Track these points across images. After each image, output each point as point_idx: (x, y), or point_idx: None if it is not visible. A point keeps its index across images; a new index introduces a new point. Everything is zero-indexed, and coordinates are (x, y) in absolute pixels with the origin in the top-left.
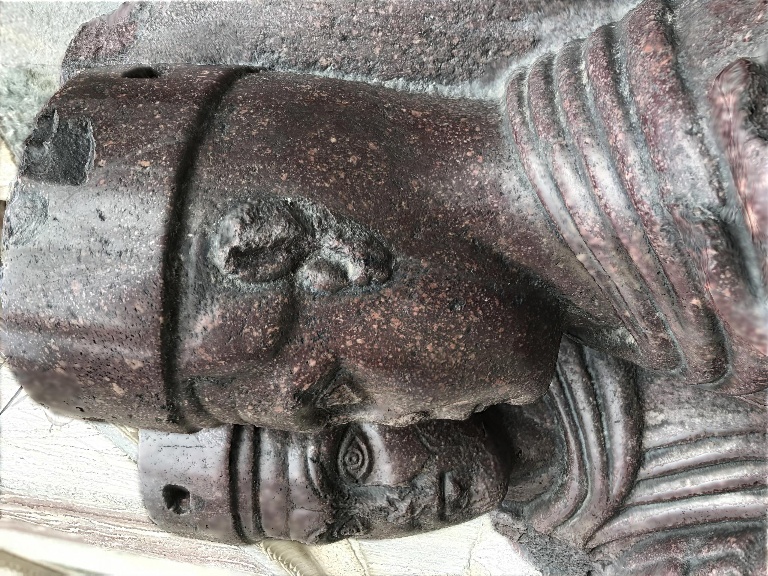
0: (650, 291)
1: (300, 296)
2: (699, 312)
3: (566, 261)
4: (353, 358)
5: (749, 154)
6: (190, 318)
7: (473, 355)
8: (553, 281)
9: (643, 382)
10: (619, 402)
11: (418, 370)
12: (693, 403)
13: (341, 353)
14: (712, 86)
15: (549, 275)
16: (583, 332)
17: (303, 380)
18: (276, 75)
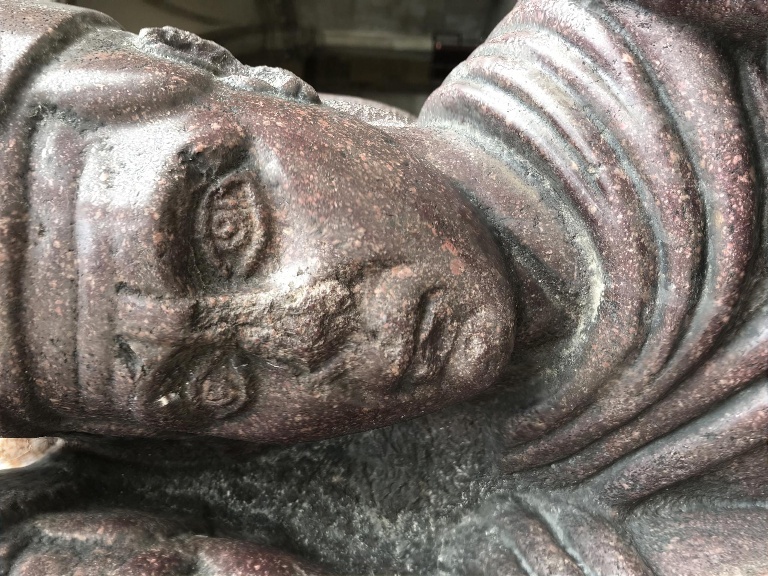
0: (584, 94)
1: (218, 84)
2: (634, 74)
3: (497, 172)
4: (268, 140)
5: None
6: (83, 51)
7: (414, 189)
8: (489, 198)
9: (649, 552)
10: (628, 575)
11: (348, 176)
12: (731, 560)
13: (254, 131)
14: None
15: (483, 189)
16: (540, 387)
17: (198, 139)
18: None
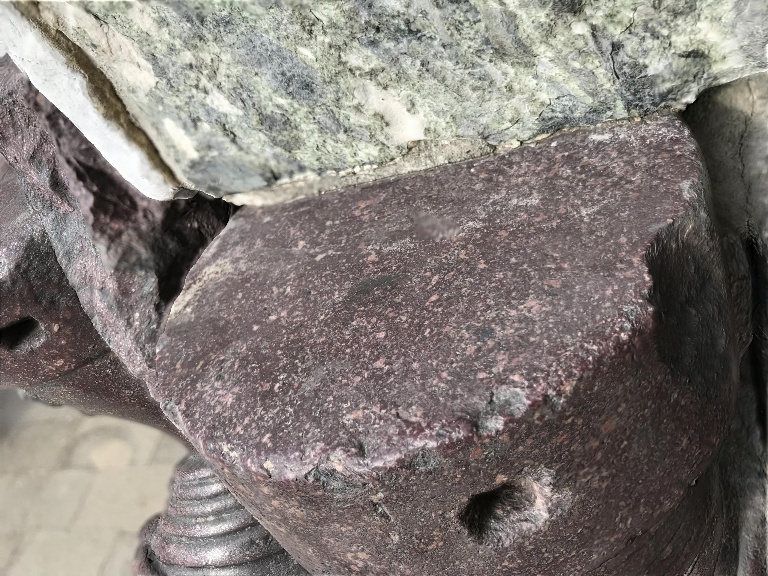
0: None
1: None
2: None
3: None
4: None
5: (140, 575)
6: None
7: None
8: None
9: None
10: None
11: None
12: None
13: None
14: (168, 574)
15: None
16: None
17: None
18: (125, 370)
